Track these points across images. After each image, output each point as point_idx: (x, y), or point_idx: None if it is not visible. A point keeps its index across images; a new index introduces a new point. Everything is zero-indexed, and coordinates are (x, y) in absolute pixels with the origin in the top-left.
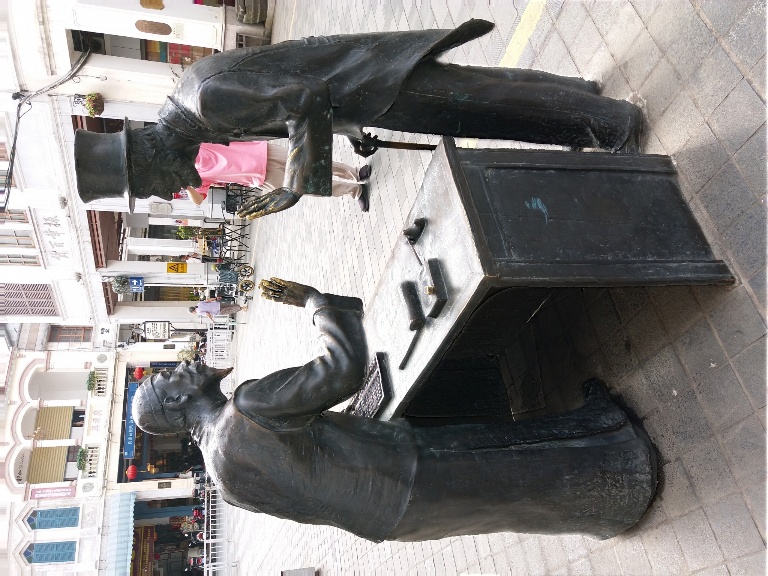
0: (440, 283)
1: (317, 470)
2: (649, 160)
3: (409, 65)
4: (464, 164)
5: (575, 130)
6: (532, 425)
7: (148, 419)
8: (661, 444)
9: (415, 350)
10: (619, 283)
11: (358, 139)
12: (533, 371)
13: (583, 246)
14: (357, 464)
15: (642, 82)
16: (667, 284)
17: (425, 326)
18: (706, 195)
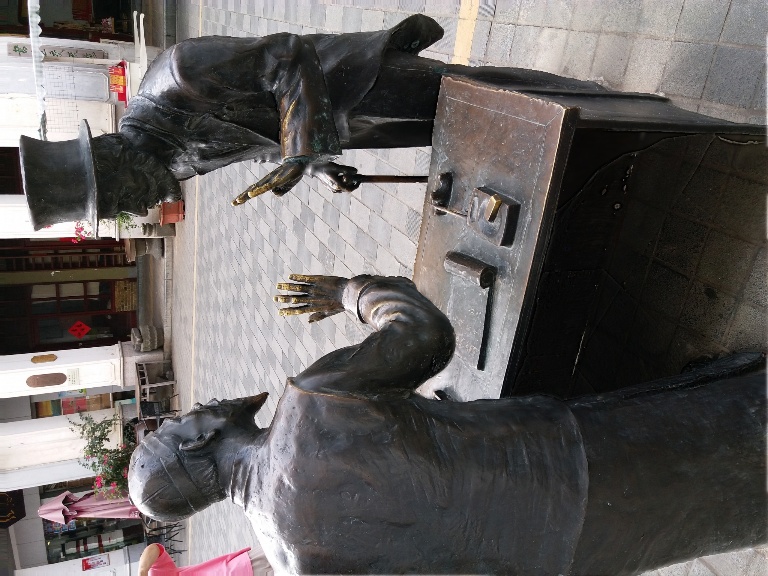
0: (502, 197)
1: (443, 451)
2: (639, 93)
3: (383, 39)
4: None
5: None
6: (670, 377)
7: (158, 483)
8: None
9: (493, 324)
10: (696, 127)
11: (338, 173)
12: None
13: None
14: (495, 429)
15: (590, 67)
16: (739, 131)
17: (497, 277)
18: (712, 91)
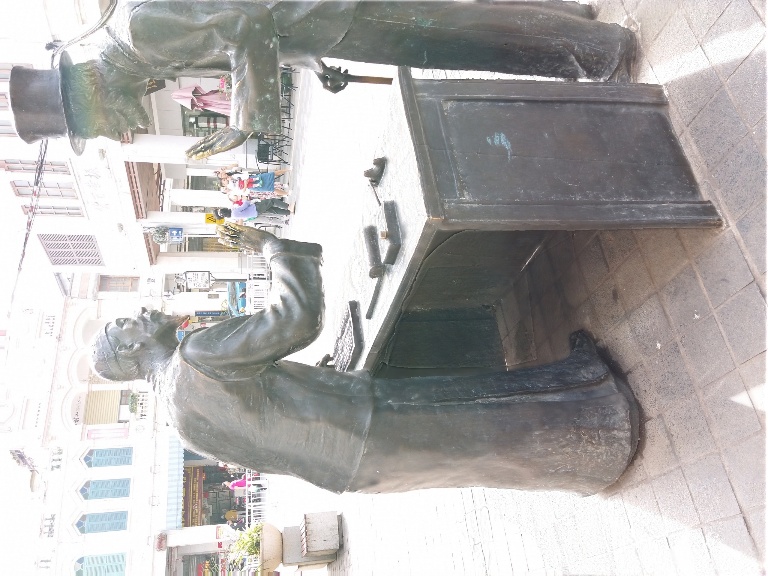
0: (395, 227)
1: (266, 421)
2: (636, 90)
3: None
4: (420, 96)
5: (557, 58)
6: (503, 378)
7: (102, 367)
8: (644, 400)
9: (379, 299)
10: (585, 226)
11: (326, 74)
12: (526, 322)
13: (548, 186)
14: (308, 416)
15: (637, 2)
16: (642, 227)
17: (386, 273)
18: (697, 128)
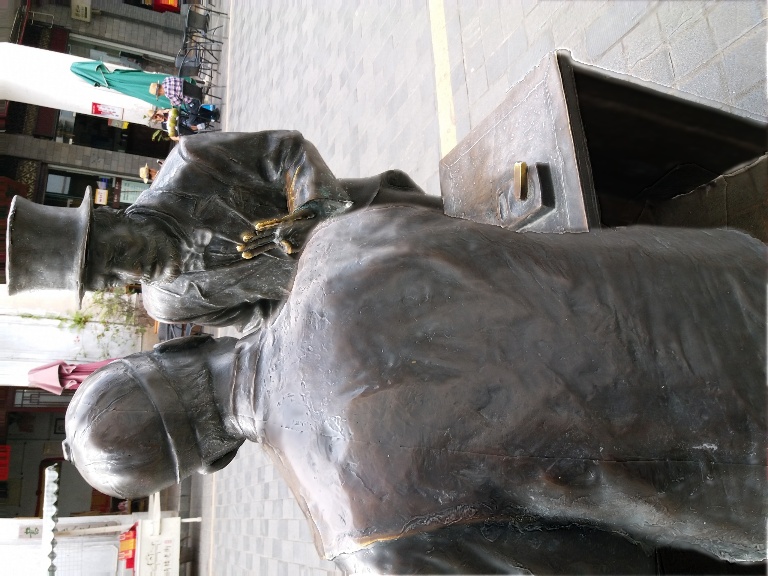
0: None
1: None
2: None
3: None
4: None
5: None
6: None
7: (116, 391)
8: None
9: None
10: (694, 96)
11: None
12: None
13: None
14: None
15: None
16: (739, 111)
17: None
18: None
